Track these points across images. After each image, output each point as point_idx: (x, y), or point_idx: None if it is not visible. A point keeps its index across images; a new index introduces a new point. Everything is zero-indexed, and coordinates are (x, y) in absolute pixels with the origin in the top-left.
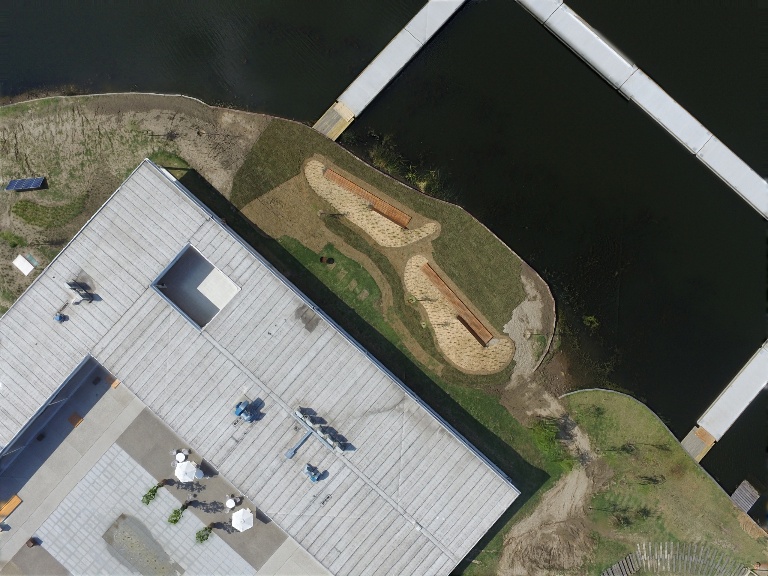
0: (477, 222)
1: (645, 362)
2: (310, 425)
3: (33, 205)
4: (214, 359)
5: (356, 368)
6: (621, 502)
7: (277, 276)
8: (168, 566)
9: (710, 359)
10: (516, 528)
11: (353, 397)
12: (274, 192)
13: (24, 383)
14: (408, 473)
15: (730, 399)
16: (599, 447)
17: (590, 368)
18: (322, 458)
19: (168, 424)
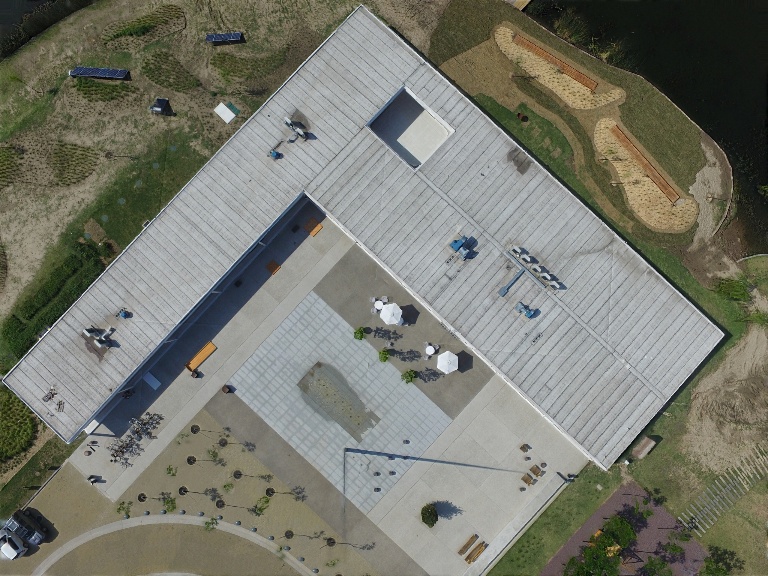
0: (658, 92)
1: None
2: (528, 260)
3: (231, 58)
4: (428, 198)
5: (567, 210)
6: None
7: (490, 119)
8: (363, 415)
9: None
10: (702, 383)
11: (564, 238)
12: (467, 54)
13: (237, 219)
14: (617, 313)
15: None
16: None
17: (764, 235)
18: (534, 297)
19: (382, 261)
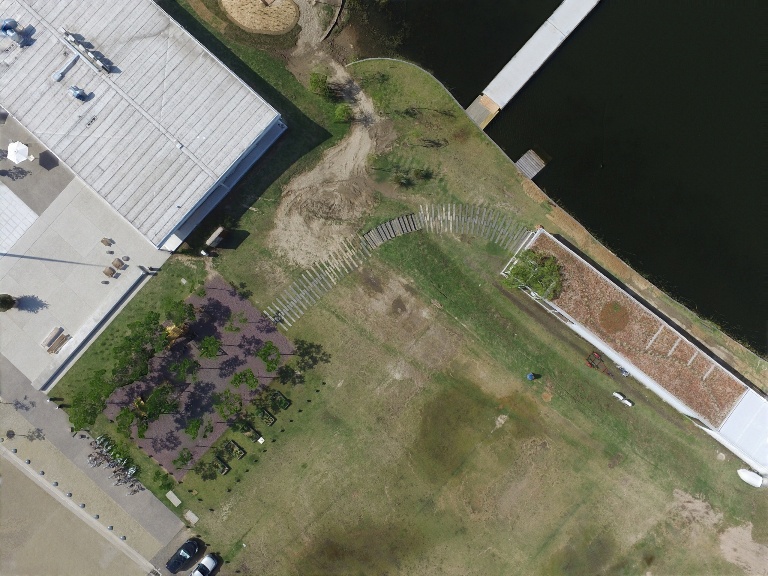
0: None
1: (433, 36)
2: (72, 39)
3: None
4: None
5: None
6: (404, 164)
7: None
8: None
9: (497, 35)
10: (296, 181)
11: (120, 23)
12: None
13: None
14: (171, 95)
15: (514, 69)
16: (382, 110)
17: (378, 41)
18: (89, 81)
19: None
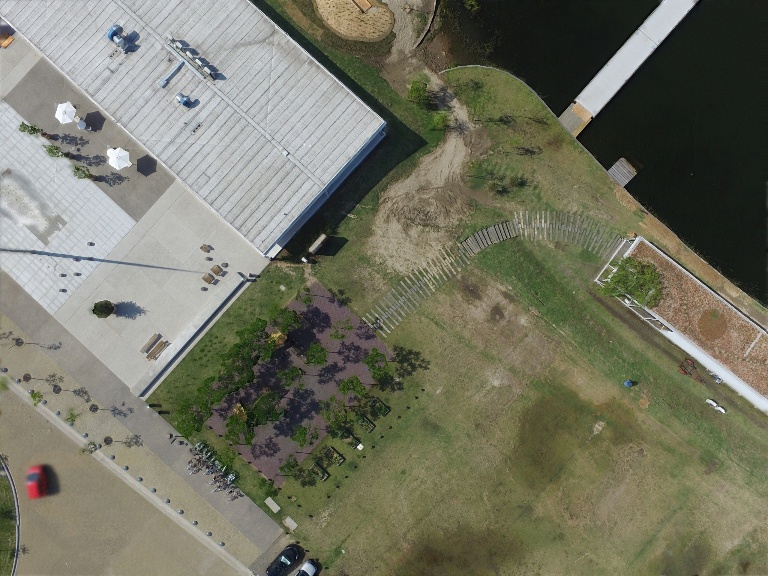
0: None
1: (524, 44)
2: (179, 46)
3: None
4: None
5: (228, 3)
6: (498, 171)
7: None
8: (51, 218)
9: (588, 43)
10: (392, 188)
11: (225, 30)
12: None
13: None
14: (277, 102)
15: (606, 77)
16: (477, 118)
17: (470, 48)
18: (194, 88)
19: (46, 55)
